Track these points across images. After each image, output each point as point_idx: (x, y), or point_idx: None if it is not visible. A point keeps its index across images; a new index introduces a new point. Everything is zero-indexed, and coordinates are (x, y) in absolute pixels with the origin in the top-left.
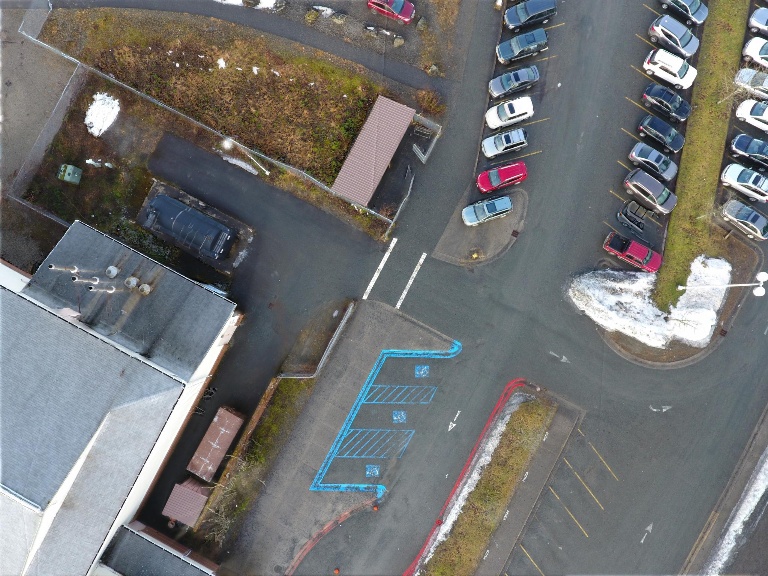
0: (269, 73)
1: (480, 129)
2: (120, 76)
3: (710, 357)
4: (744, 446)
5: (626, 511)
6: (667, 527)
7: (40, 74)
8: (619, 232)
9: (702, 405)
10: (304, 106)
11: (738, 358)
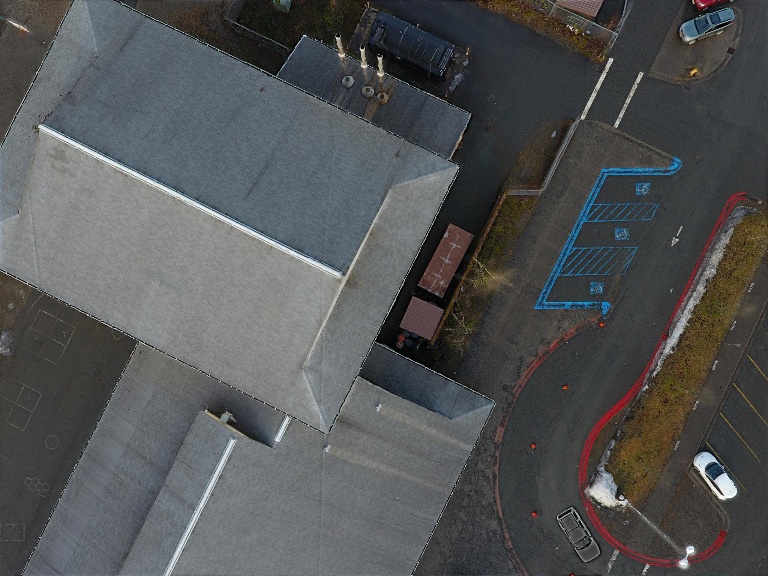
0: None
1: None
2: None
3: None
4: None
5: None
6: None
7: None
8: None
9: None
10: None
11: None
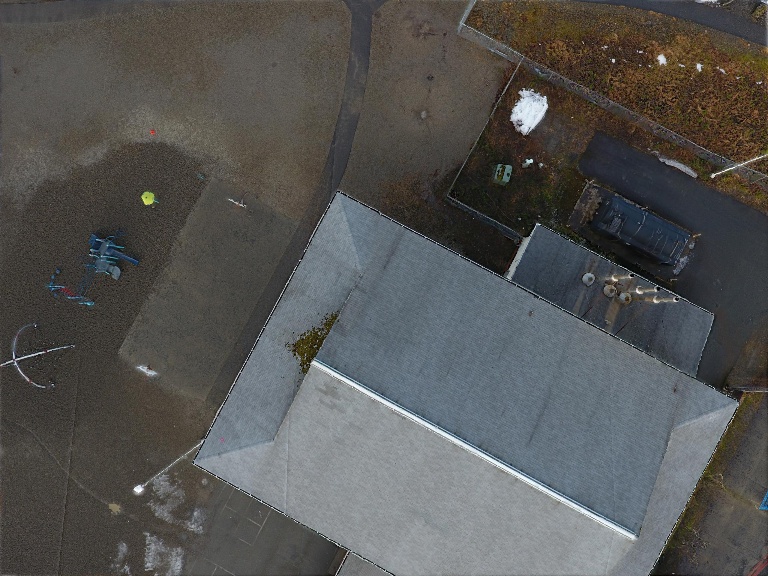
0: (715, 70)
1: None
2: (547, 71)
3: None
4: None
5: None
6: None
7: (465, 68)
8: None
9: None
10: (755, 106)
11: None
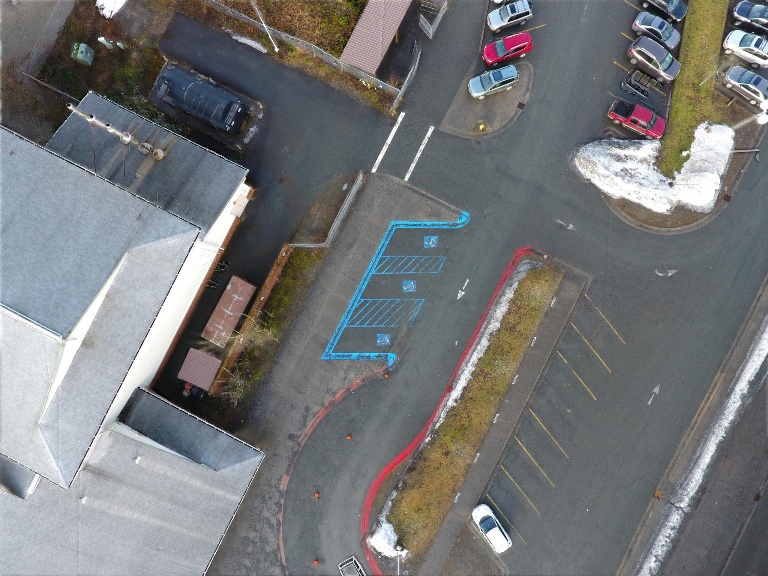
0: None
1: (485, 4)
2: None
3: (714, 222)
4: (749, 307)
5: (633, 374)
6: (674, 388)
7: None
8: (623, 98)
9: (707, 268)
10: None
11: (742, 222)
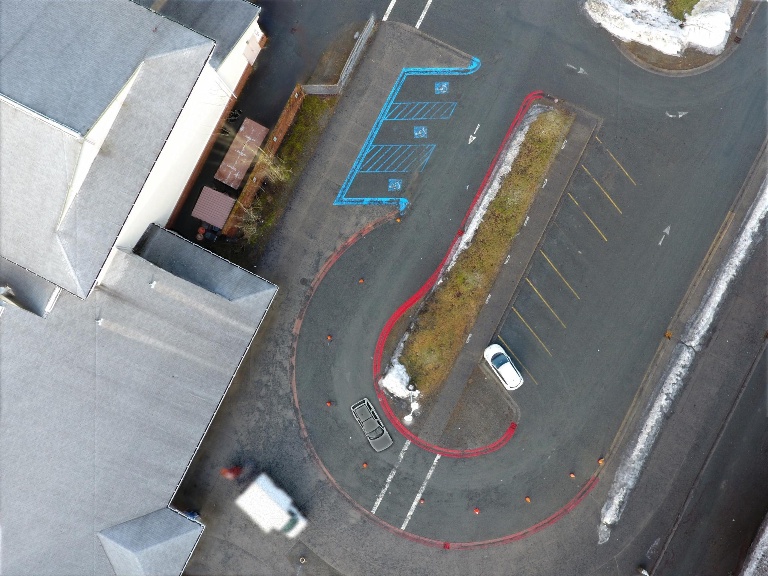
0: None
1: None
2: None
3: (725, 63)
4: (759, 147)
5: (644, 215)
6: (684, 229)
7: None
8: None
9: (717, 109)
10: None
11: (752, 63)
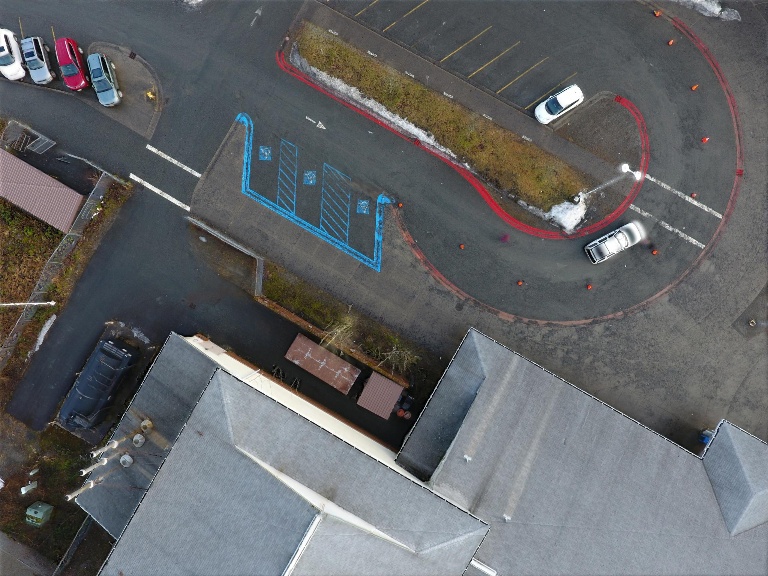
0: None
1: (25, 86)
2: None
3: None
4: None
5: None
6: None
7: None
8: None
9: None
10: None
11: None
